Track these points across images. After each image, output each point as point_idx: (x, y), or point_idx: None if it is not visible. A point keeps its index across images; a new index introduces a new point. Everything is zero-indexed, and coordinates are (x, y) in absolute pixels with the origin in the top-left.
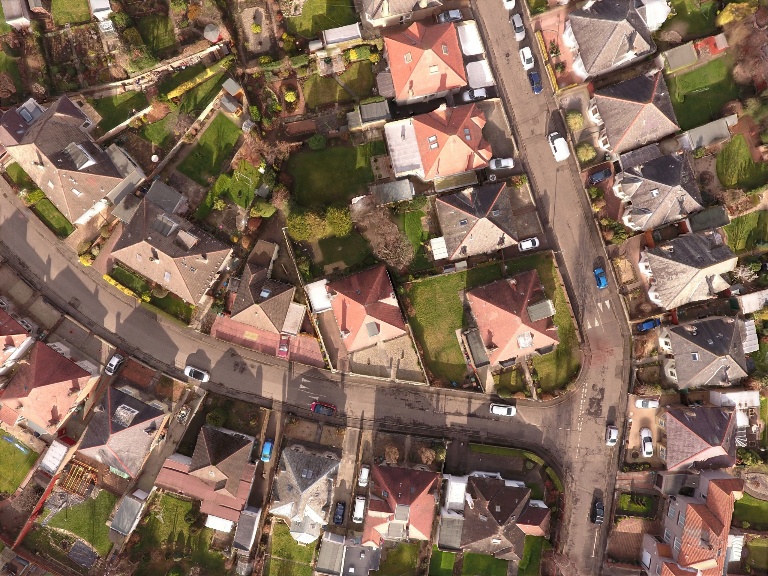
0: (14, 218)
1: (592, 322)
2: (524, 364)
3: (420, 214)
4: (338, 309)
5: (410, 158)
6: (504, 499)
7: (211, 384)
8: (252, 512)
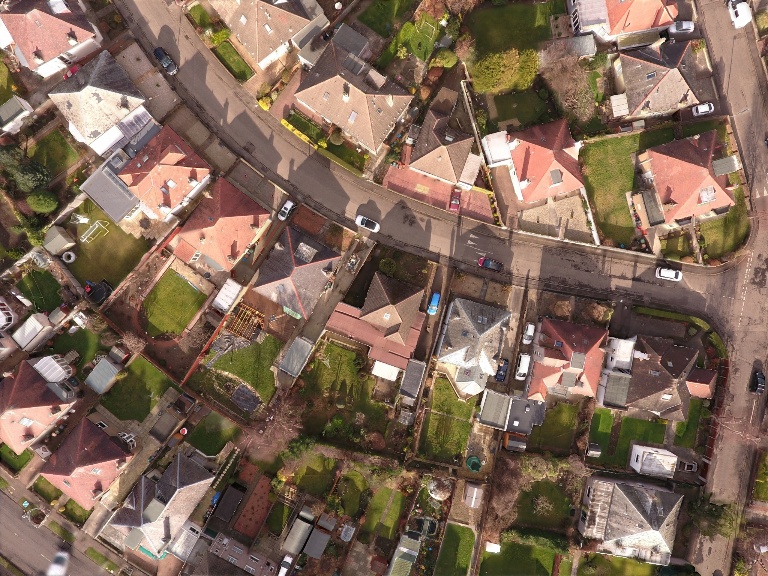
0: (194, 60)
1: (761, 191)
2: (692, 230)
3: (596, 75)
4: (519, 158)
5: (597, 12)
6: (674, 356)
7: (380, 236)
8: (419, 361)
